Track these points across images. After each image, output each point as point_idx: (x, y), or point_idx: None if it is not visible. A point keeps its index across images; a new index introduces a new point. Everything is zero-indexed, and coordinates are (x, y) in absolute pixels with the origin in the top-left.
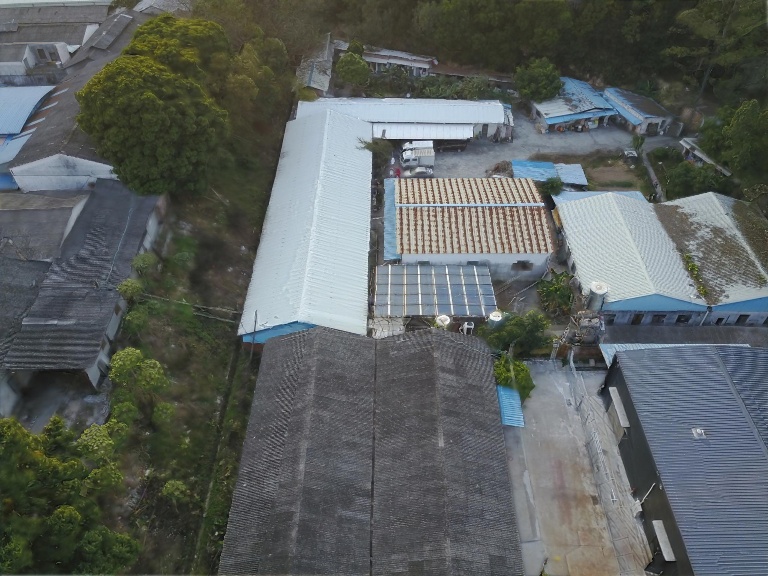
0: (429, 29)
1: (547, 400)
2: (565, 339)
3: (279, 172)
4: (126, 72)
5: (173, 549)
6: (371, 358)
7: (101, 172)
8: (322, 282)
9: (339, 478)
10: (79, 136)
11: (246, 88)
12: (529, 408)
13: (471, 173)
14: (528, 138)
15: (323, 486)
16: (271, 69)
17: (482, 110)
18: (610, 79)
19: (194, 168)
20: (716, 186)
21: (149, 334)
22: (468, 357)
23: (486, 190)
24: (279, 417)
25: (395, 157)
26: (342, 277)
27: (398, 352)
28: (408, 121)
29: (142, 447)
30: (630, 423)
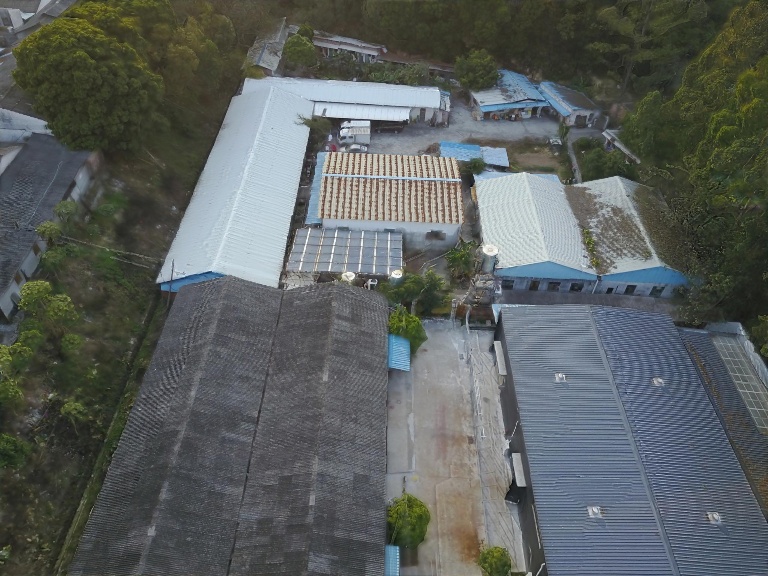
0: (376, 17)
1: (442, 354)
2: (464, 300)
3: (218, 141)
4: (62, 32)
5: (69, 466)
6: (276, 306)
7: (36, 127)
8: (241, 239)
9: (228, 405)
10: (17, 92)
11: (187, 58)
12: (424, 360)
13: (404, 153)
14: (463, 124)
15: (211, 411)
16: (218, 45)
17: (420, 95)
18: (548, 74)
19: (126, 127)
20: (626, 172)
21: (67, 276)
22: (366, 308)
23: (410, 166)
24: (180, 352)
25: (333, 134)
26: (262, 236)
27: (301, 301)
28: (349, 102)
29: (47, 373)
30: (507, 371)
